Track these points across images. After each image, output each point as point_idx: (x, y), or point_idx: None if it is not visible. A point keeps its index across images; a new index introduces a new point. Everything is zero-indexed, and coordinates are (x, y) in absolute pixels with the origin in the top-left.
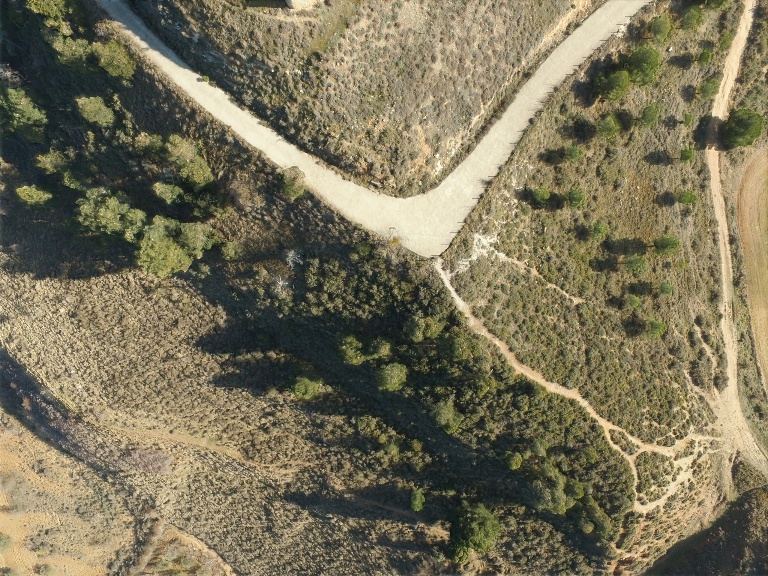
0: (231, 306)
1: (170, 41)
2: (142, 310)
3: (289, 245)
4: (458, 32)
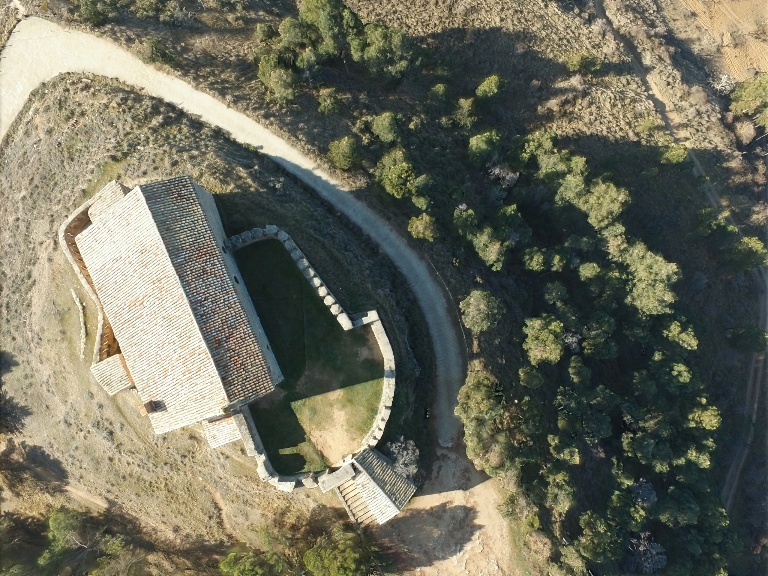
0: (291, 13)
1: (291, 180)
2: (386, 5)
3: (194, 34)
4: (7, 235)
